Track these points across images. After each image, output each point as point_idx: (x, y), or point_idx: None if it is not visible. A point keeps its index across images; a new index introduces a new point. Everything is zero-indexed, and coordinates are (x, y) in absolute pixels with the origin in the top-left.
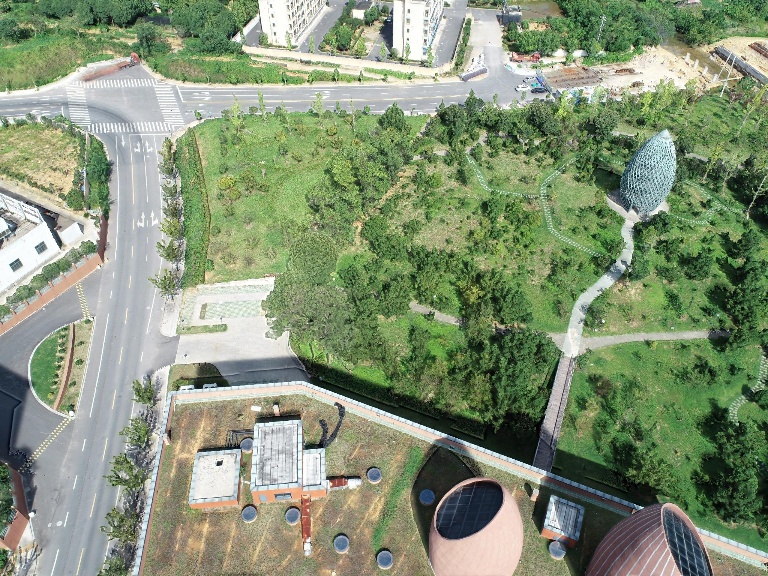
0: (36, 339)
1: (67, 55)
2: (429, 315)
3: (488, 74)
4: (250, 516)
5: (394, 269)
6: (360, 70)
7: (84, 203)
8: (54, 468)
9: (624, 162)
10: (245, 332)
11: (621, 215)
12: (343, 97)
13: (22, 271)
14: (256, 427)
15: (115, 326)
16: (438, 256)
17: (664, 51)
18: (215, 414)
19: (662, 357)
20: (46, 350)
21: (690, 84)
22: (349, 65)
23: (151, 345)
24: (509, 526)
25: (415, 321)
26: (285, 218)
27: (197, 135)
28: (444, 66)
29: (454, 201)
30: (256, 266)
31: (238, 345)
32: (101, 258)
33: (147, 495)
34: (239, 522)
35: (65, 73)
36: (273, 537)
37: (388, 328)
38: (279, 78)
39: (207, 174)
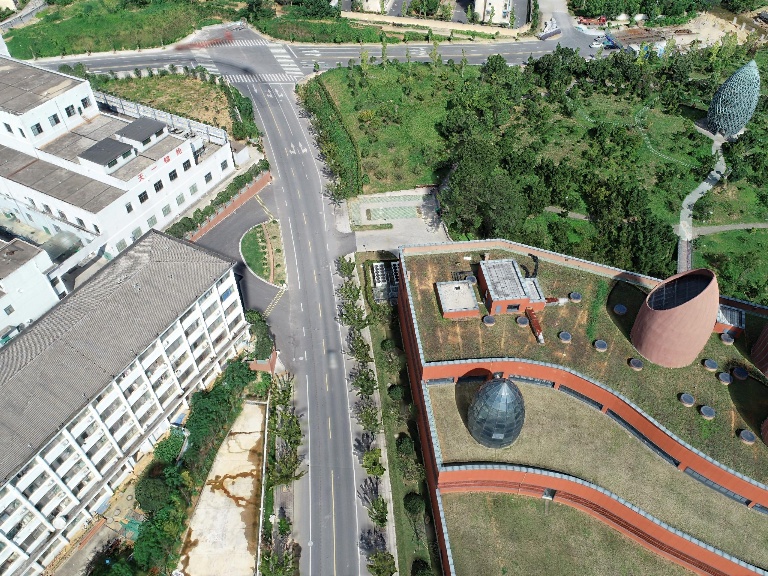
0: (238, 234)
1: (183, 19)
2: (563, 212)
3: (562, 34)
4: (491, 321)
5: (524, 180)
6: (449, 31)
7: (246, 133)
8: (284, 322)
9: (701, 100)
10: (409, 229)
11: (709, 137)
12: (438, 53)
13: (211, 184)
14: (481, 263)
15: (298, 226)
16: (565, 167)
17: (713, 16)
18: (437, 262)
19: (761, 240)
20: (250, 241)
21: (752, 36)
22: (437, 27)
23: (332, 239)
24: (717, 294)
25: (551, 218)
26: (422, 143)
27: (324, 81)
28: (523, 27)
29: (563, 130)
30: (405, 180)
31: (406, 238)
32: (270, 176)
33: (365, 339)
34: (482, 326)
35: (184, 35)
36: (511, 334)
37: (529, 224)
38: (377, 38)
39: (343, 111)
